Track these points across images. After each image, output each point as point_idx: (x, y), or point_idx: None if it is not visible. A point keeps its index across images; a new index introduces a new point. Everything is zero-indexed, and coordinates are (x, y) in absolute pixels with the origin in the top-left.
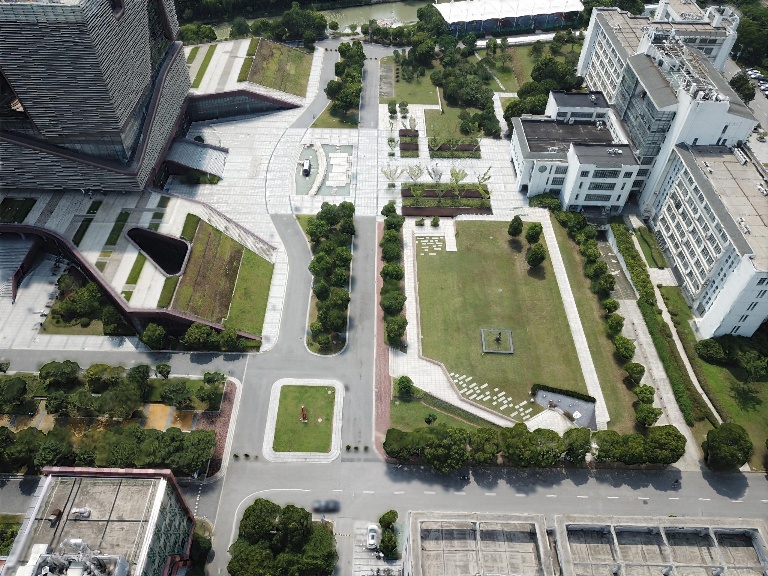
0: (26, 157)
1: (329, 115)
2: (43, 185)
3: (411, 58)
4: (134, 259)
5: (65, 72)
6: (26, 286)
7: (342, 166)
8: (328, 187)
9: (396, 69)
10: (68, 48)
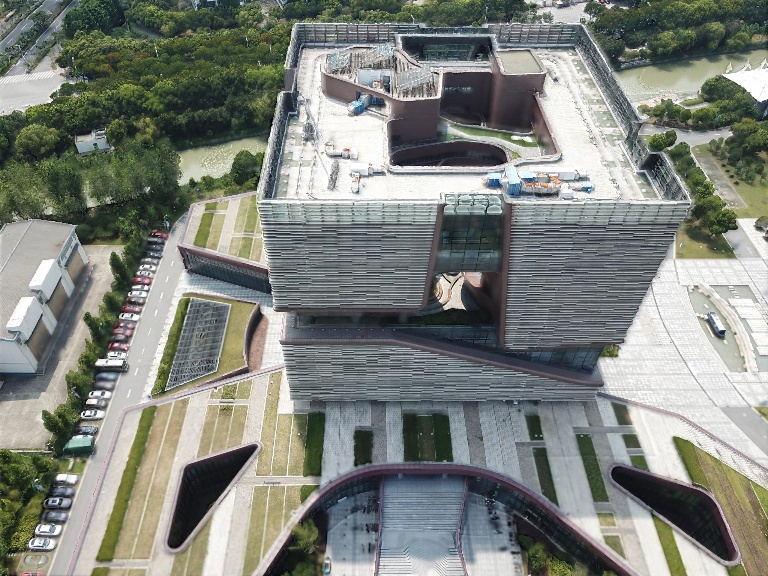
0: (461, 370)
1: (689, 239)
2: (461, 397)
3: (739, 151)
4: (653, 529)
5: (598, 280)
6: (471, 556)
7: (759, 321)
8: (764, 357)
9: (722, 165)
10: (628, 253)
